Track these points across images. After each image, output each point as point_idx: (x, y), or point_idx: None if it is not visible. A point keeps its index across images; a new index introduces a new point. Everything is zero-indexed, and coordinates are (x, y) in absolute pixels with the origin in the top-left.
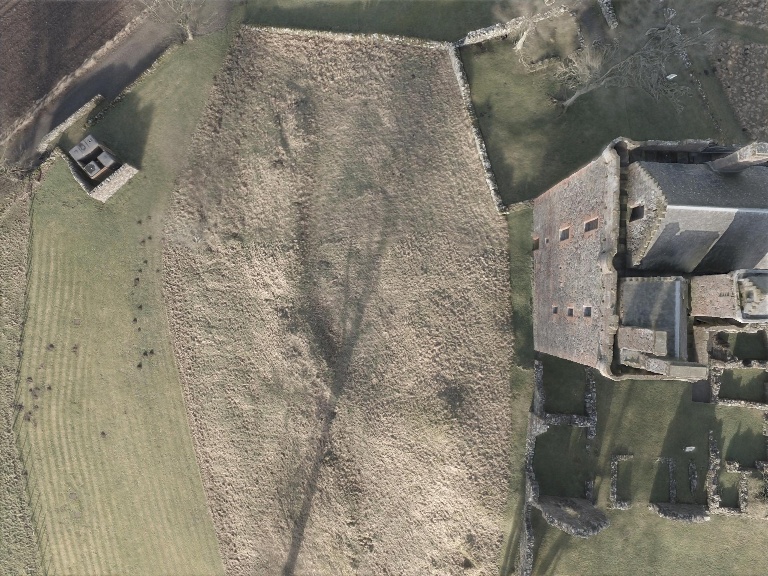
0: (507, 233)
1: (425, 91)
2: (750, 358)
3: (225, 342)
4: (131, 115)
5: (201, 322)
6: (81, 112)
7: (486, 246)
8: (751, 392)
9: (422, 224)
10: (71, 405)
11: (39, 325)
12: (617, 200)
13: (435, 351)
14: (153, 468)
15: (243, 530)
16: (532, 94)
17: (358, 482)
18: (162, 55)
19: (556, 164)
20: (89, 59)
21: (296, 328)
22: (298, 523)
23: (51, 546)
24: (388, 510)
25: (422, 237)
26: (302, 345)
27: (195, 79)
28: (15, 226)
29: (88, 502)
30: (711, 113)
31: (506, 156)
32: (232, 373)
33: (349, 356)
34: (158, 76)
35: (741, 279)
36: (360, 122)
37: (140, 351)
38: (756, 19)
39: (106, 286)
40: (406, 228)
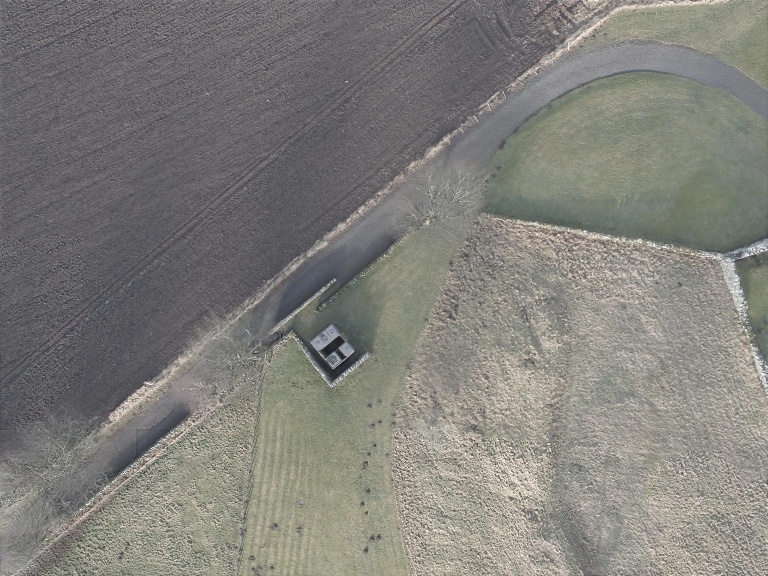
0: None
1: (693, 301)
2: None
3: (460, 534)
4: (364, 298)
5: (433, 510)
6: (316, 296)
7: None
8: None
9: (696, 443)
10: None
11: (263, 503)
12: None
13: None
14: None
15: None
16: None
17: None
18: (399, 241)
19: None
20: (321, 240)
21: (549, 534)
22: None
23: None
24: None
25: (697, 457)
26: (555, 552)
27: (430, 264)
28: (243, 405)
29: None
30: None
31: None
32: (467, 565)
33: (606, 566)
34: (393, 260)
35: None
36: (618, 325)
37: (367, 535)
38: None
39: (333, 468)
40: (678, 445)
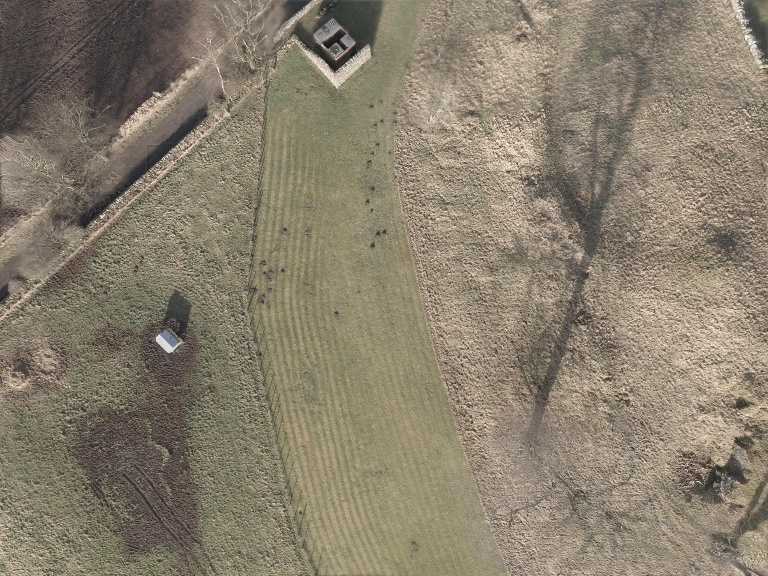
0: None
1: None
2: None
3: (462, 217)
4: (363, 3)
5: (435, 200)
6: (317, 0)
7: (748, 99)
8: None
9: (680, 82)
10: (304, 286)
11: (272, 210)
12: None
13: (700, 202)
14: (387, 345)
15: (481, 400)
16: None
17: (613, 339)
18: None
19: None
20: None
21: (545, 193)
22: (543, 388)
23: (285, 425)
24: (647, 363)
25: (681, 94)
26: (552, 210)
27: None
28: (249, 114)
29: (322, 381)
30: None
31: (762, 14)
32: (469, 247)
33: (599, 218)
34: None
35: None
36: None
37: (373, 231)
38: None
39: (339, 169)
40: (663, 87)
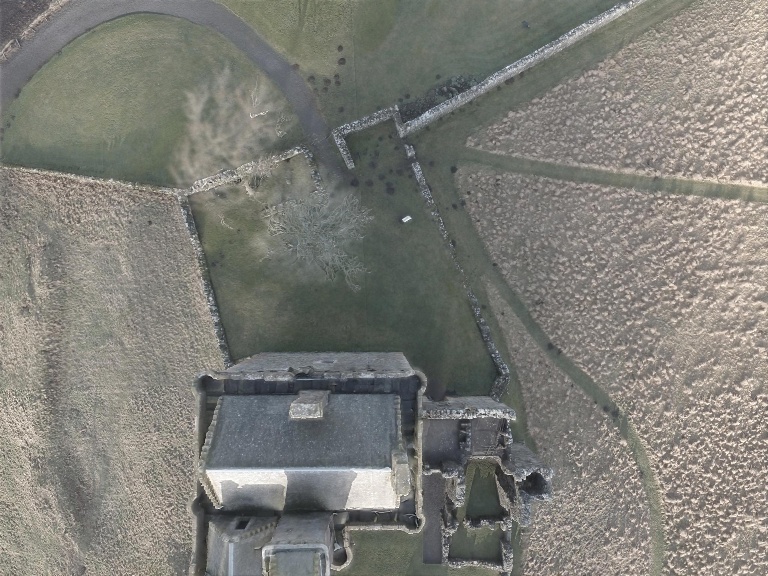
0: None
1: (161, 238)
2: (483, 515)
3: None
4: None
5: None
6: None
7: None
8: (486, 550)
9: (155, 379)
10: None
11: None
12: (196, 441)
13: (167, 512)
14: None
15: None
16: (267, 240)
17: None
18: None
19: (288, 314)
20: None
21: (45, 480)
22: None
23: None
24: None
25: (155, 393)
26: (51, 498)
27: None
28: None
29: None
30: (453, 253)
31: (237, 308)
32: None
33: (98, 509)
34: None
35: (270, 555)
36: (103, 268)
37: None
38: (509, 147)
39: None
40: (140, 383)
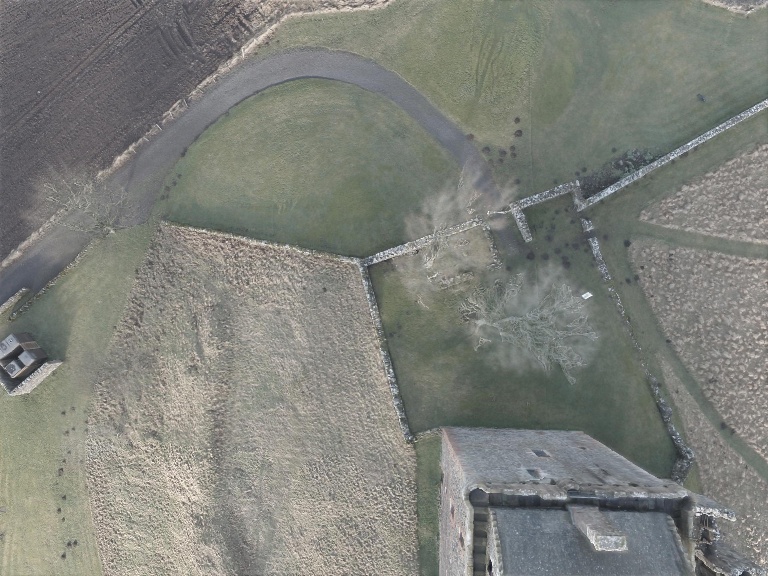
0: (415, 462)
1: (336, 306)
2: None
3: (145, 539)
4: (55, 307)
5: (123, 516)
6: (6, 306)
7: (393, 475)
8: None
9: (330, 447)
10: None
11: None
12: (470, 556)
13: None
14: None
15: None
16: (444, 312)
17: None
18: (84, 250)
19: (466, 388)
20: (15, 250)
21: (209, 539)
22: None
23: None
24: None
25: (330, 461)
26: (215, 556)
27: (117, 272)
28: None
29: None
30: (630, 330)
31: (415, 380)
32: (152, 570)
33: (262, 570)
34: (81, 269)
35: None
36: (273, 331)
37: (64, 541)
38: (682, 222)
39: (31, 475)
40: (315, 450)
